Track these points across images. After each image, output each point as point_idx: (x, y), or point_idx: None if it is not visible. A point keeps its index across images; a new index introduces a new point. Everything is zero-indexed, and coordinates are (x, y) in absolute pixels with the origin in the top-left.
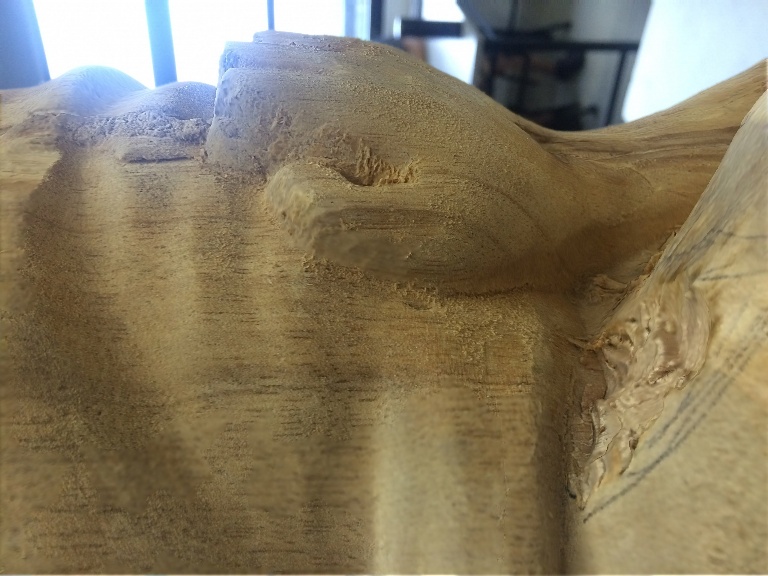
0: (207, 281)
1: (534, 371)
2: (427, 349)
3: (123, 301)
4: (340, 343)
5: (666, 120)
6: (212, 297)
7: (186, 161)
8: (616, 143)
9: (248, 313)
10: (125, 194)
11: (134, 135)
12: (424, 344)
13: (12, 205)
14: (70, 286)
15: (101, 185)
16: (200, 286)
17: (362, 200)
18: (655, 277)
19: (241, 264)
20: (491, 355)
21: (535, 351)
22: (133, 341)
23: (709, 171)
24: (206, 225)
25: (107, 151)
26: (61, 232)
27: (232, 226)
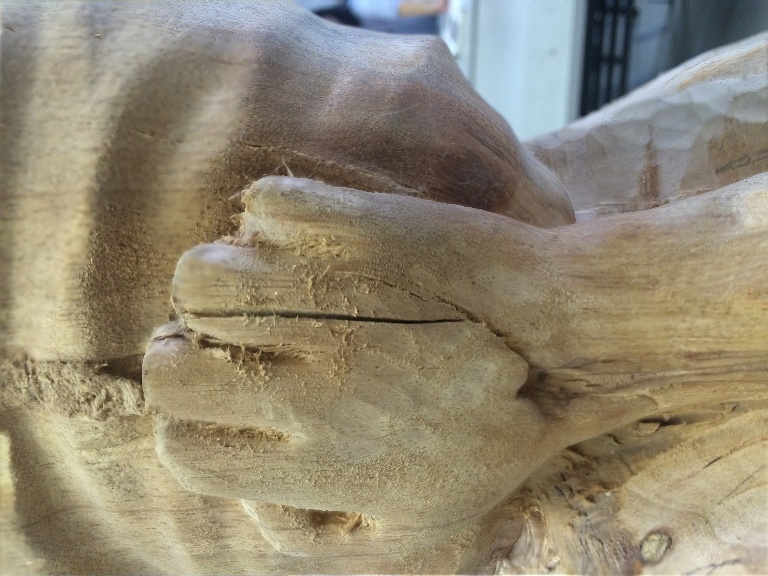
0: (201, 560)
1: (456, 575)
2: (377, 571)
3: (137, 553)
4: (311, 572)
5: (742, 317)
6: (208, 567)
7: (142, 439)
8: (649, 360)
9: (238, 569)
10: (99, 490)
11: (72, 413)
12: (376, 568)
13: (8, 526)
14: (92, 556)
15: (67, 464)
16: (196, 563)
17: (324, 554)
18: (572, 568)
19: (225, 542)
20: (427, 567)
21: (463, 558)
22: (156, 567)
23: (739, 391)
24: (186, 519)
25: (51, 423)
26: (59, 516)
27: (209, 515)
